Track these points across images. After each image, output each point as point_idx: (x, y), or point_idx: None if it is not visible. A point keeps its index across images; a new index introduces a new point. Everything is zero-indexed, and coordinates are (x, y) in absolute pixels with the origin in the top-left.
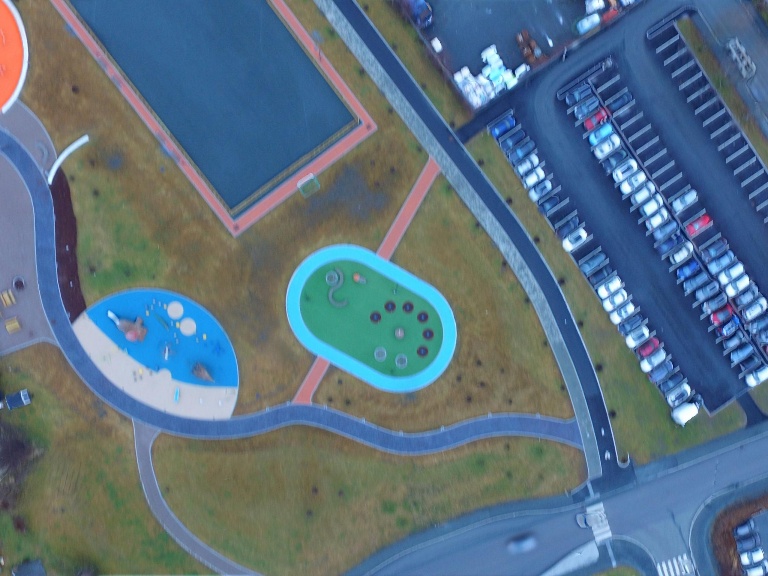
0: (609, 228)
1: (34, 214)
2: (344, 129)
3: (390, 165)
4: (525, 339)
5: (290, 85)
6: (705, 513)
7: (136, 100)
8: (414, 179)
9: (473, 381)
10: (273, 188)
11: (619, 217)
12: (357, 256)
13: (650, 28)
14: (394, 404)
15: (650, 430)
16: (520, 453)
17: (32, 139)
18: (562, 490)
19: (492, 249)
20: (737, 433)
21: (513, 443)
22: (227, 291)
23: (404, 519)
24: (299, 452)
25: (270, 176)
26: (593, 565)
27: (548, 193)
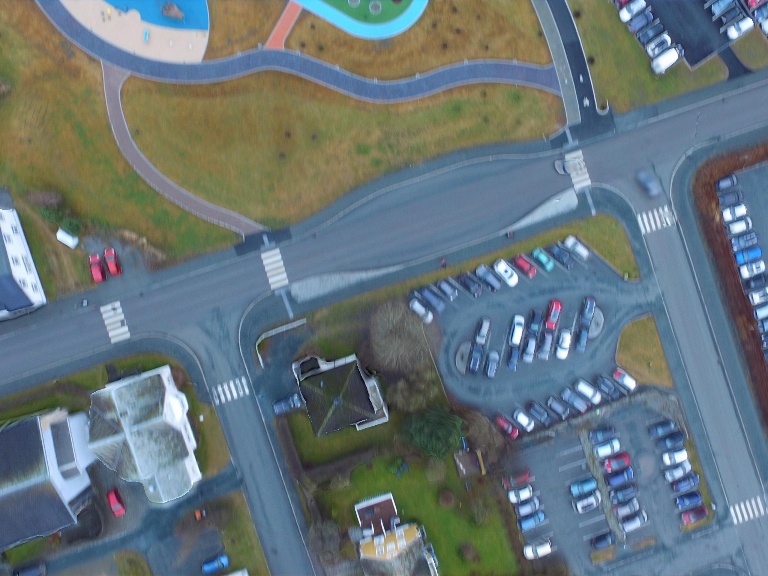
0: None
1: None
2: None
3: None
4: None
5: None
6: (686, 164)
7: None
8: None
9: (449, 28)
10: None
11: None
12: None
13: None
14: (368, 51)
15: (629, 78)
16: (497, 99)
17: None
18: (540, 134)
19: None
20: (718, 85)
21: (490, 90)
22: None
23: (378, 159)
24: (271, 97)
25: None
26: (572, 212)
27: None
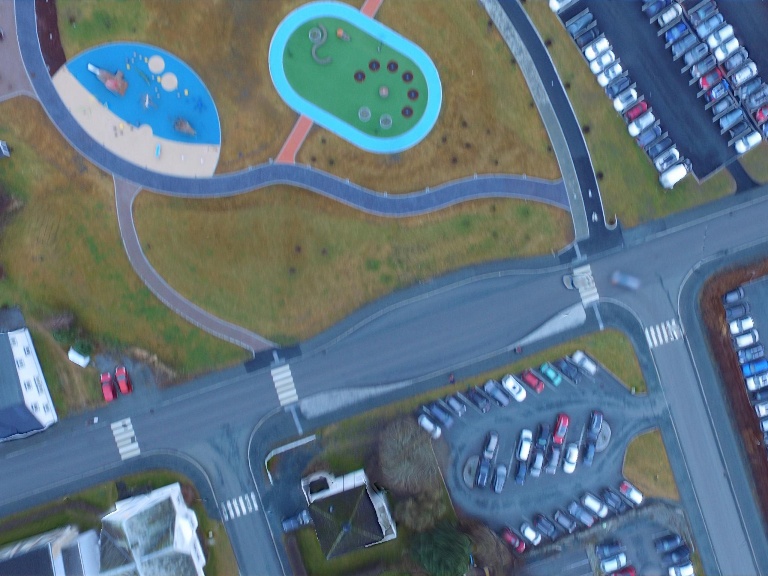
0: None
1: None
2: None
3: None
4: (511, 100)
5: None
6: (694, 278)
7: None
8: None
9: (458, 142)
10: None
11: None
12: (341, 13)
13: None
14: (378, 165)
15: (638, 193)
16: (506, 214)
17: None
18: (549, 250)
19: (478, 8)
20: (726, 199)
21: (499, 204)
22: (209, 46)
23: (388, 276)
24: (282, 211)
25: None
26: (580, 327)
27: None
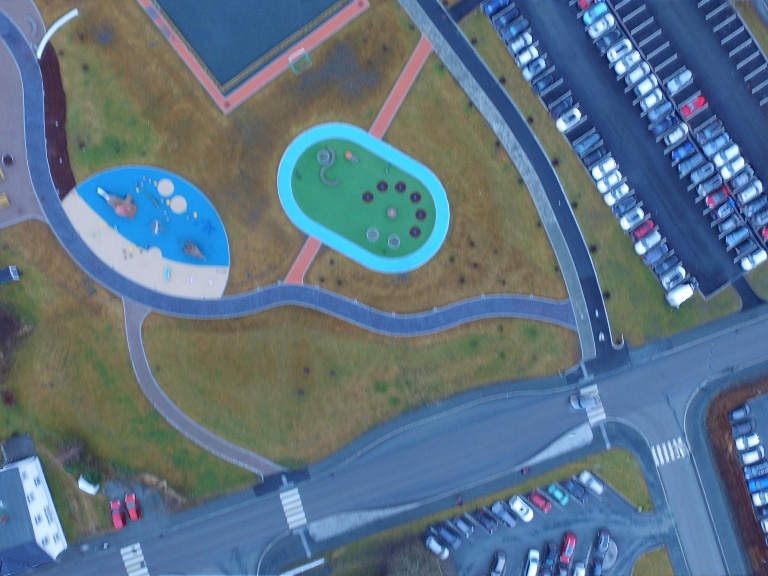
0: (603, 109)
1: (23, 89)
2: (336, 6)
3: (382, 43)
4: (518, 220)
5: None
6: (700, 396)
7: None
8: (407, 57)
9: (466, 262)
10: (264, 65)
11: (613, 98)
12: (349, 135)
13: None
14: (386, 285)
15: (644, 312)
16: (513, 334)
17: (21, 13)
18: (556, 371)
19: (485, 129)
20: (732, 316)
21: (506, 324)
22: (218, 169)
23: (396, 398)
24: (291, 332)
25: (261, 52)
26: (587, 447)
27: (542, 73)
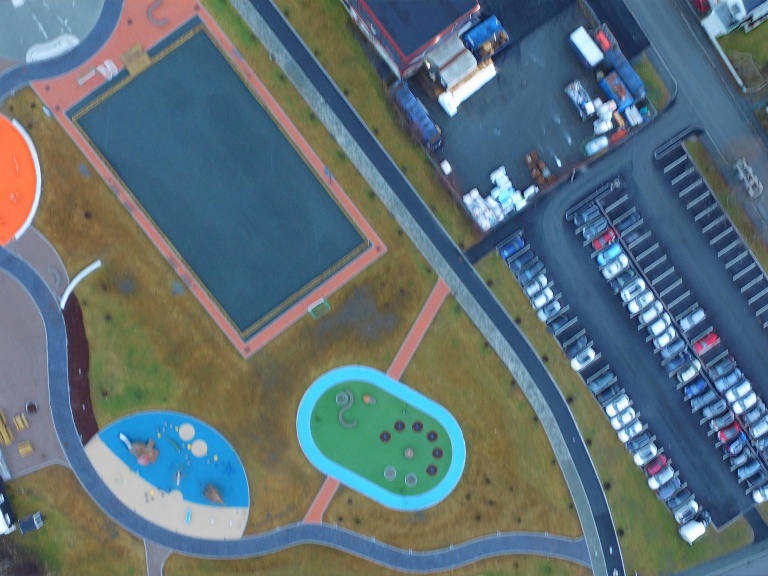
0: (617, 346)
1: (47, 338)
2: (354, 251)
3: (400, 286)
4: (534, 458)
5: (301, 208)
6: None
7: (148, 225)
8: (423, 300)
9: (482, 500)
10: (284, 310)
11: (627, 335)
12: (367, 377)
13: (658, 148)
14: (404, 523)
15: (658, 548)
16: (529, 572)
17: (45, 264)
18: None
19: (501, 368)
20: (744, 549)
21: (522, 562)
22: (238, 412)
23: None
24: (309, 571)
25: (281, 299)
26: None
27: (556, 312)
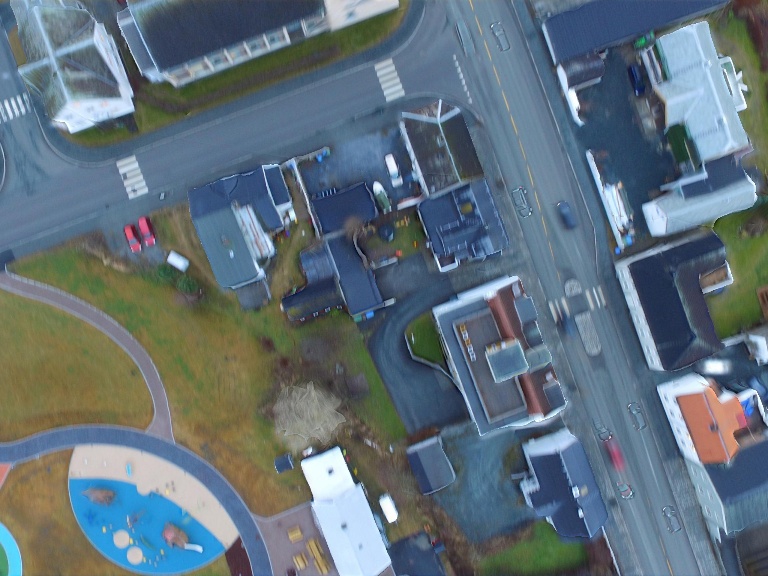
0: None
1: None
2: None
3: None
4: None
5: None
6: None
7: None
8: None
9: None
10: None
11: None
12: None
13: None
14: None
15: None
16: None
17: None
18: None
19: None
20: None
21: None
22: None
23: None
24: (1, 414)
25: None
26: None
27: None
